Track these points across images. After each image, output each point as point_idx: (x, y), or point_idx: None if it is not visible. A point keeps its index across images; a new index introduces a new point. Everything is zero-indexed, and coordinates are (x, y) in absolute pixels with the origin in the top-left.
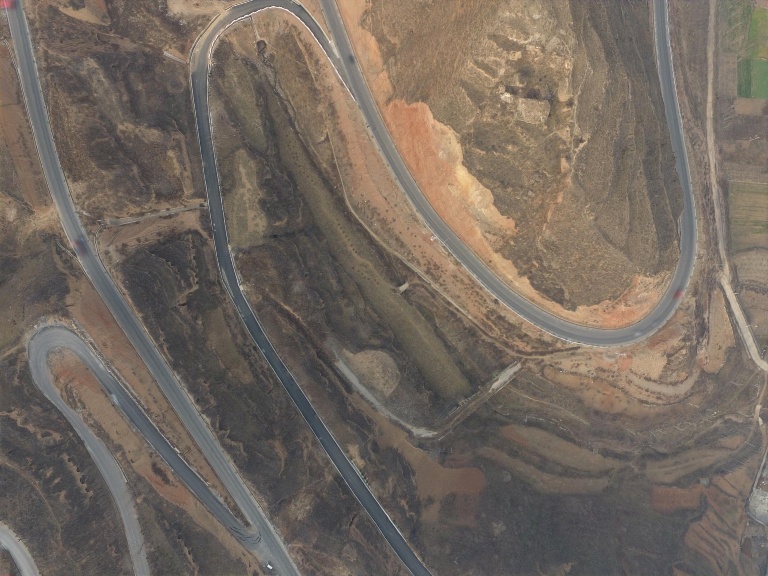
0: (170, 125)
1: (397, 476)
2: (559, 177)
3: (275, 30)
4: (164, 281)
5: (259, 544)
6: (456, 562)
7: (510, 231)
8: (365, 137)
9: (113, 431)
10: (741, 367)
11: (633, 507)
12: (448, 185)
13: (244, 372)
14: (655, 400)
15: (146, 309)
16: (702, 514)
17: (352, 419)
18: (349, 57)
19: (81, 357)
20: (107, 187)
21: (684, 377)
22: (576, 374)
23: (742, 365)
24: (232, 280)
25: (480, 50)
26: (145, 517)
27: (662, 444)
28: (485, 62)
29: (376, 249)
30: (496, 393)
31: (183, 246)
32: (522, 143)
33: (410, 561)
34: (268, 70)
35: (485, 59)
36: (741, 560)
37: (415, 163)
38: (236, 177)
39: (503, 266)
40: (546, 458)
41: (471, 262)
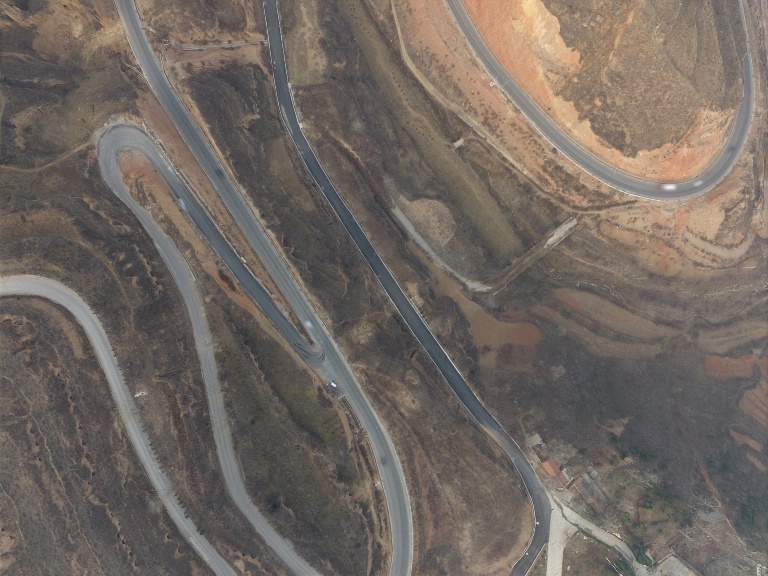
0: None
1: (454, 320)
2: None
3: None
4: (229, 101)
5: (323, 362)
6: (516, 402)
7: (574, 67)
8: None
9: (182, 230)
10: None
11: (687, 373)
12: (512, 20)
13: (306, 200)
14: (710, 263)
15: (213, 121)
16: (756, 383)
17: (410, 260)
18: None
19: (150, 158)
20: (174, 4)
21: (739, 240)
22: (632, 231)
23: None
24: (292, 117)
25: None
26: (213, 316)
27: (714, 315)
28: None
29: (431, 104)
30: (549, 256)
31: (246, 73)
32: None
33: (469, 401)
34: None
35: None
36: None
37: (476, 5)
38: (297, 16)
39: (563, 112)
40: (598, 323)
41: (530, 109)
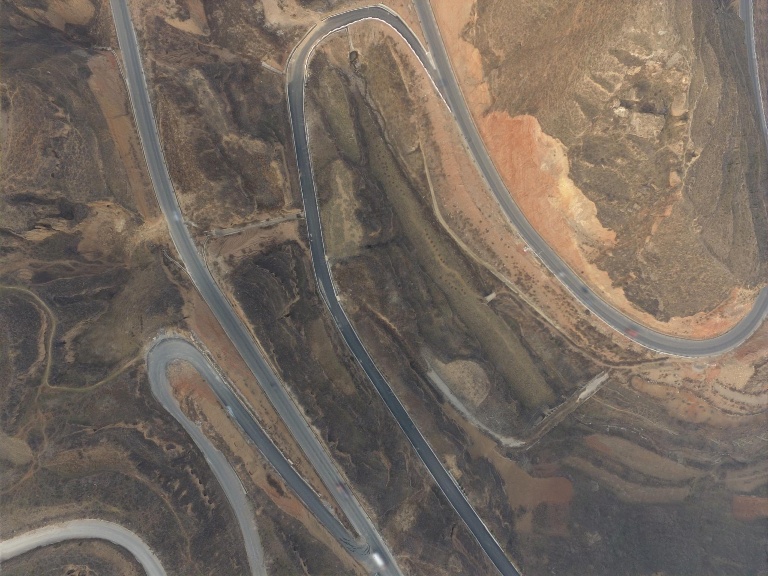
0: (271, 136)
1: (491, 486)
2: (668, 190)
3: (369, 41)
4: (271, 292)
5: (368, 555)
6: (553, 572)
7: (609, 243)
8: (460, 148)
9: (232, 443)
10: None
11: (715, 516)
12: (548, 197)
13: (346, 383)
14: (739, 410)
15: (257, 321)
16: None
17: (448, 429)
18: (446, 68)
19: (198, 369)
20: (216, 198)
21: (767, 387)
22: (663, 384)
23: None
24: (329, 290)
25: (599, 65)
26: (264, 529)
27: (741, 453)
28: (603, 77)
29: (463, 259)
30: None
31: (286, 257)
32: (632, 156)
33: (507, 571)
34: (359, 80)
35: (603, 74)
36: None
37: (511, 174)
38: (333, 188)
39: (596, 277)
40: (628, 467)
41: (563, 273)
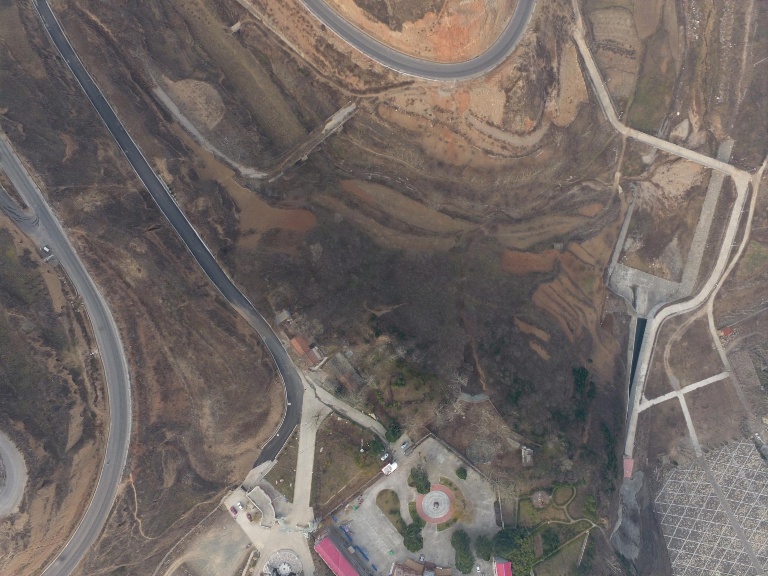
0: None
1: (213, 201)
2: None
3: None
4: None
5: (36, 227)
6: (266, 279)
7: None
8: None
9: None
10: (597, 128)
11: (480, 266)
12: None
13: (37, 67)
14: (501, 150)
15: None
16: (554, 277)
17: (163, 137)
18: None
19: None
20: None
21: (531, 127)
22: (413, 114)
23: (598, 127)
24: None
25: None
26: None
27: (516, 209)
28: None
29: None
30: (338, 147)
31: None
32: None
33: (219, 279)
34: None
35: None
36: (598, 330)
37: None
38: None
39: None
40: (390, 215)
41: None
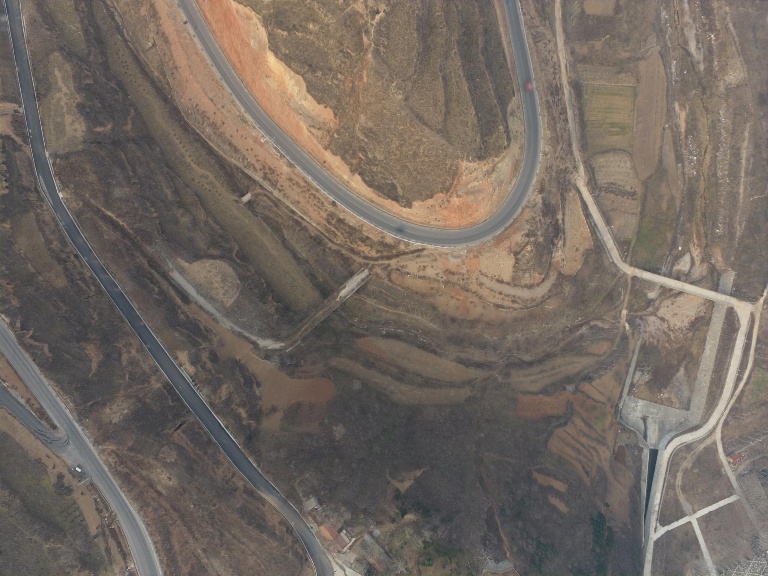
0: None
1: (234, 384)
2: (362, 54)
3: None
4: None
5: (67, 447)
6: (292, 466)
7: (332, 123)
8: (186, 36)
9: None
10: (603, 270)
11: (495, 415)
12: (265, 77)
13: (57, 276)
14: (511, 304)
15: None
16: (567, 420)
17: (183, 326)
18: None
19: None
20: None
21: (539, 279)
22: (425, 278)
23: (604, 269)
24: (51, 187)
25: None
26: None
27: (527, 353)
28: None
29: (216, 159)
30: (351, 305)
31: None
32: (322, 20)
33: (245, 468)
34: None
35: None
36: (612, 466)
37: (238, 61)
38: (52, 81)
39: (337, 165)
40: (405, 370)
41: (305, 163)
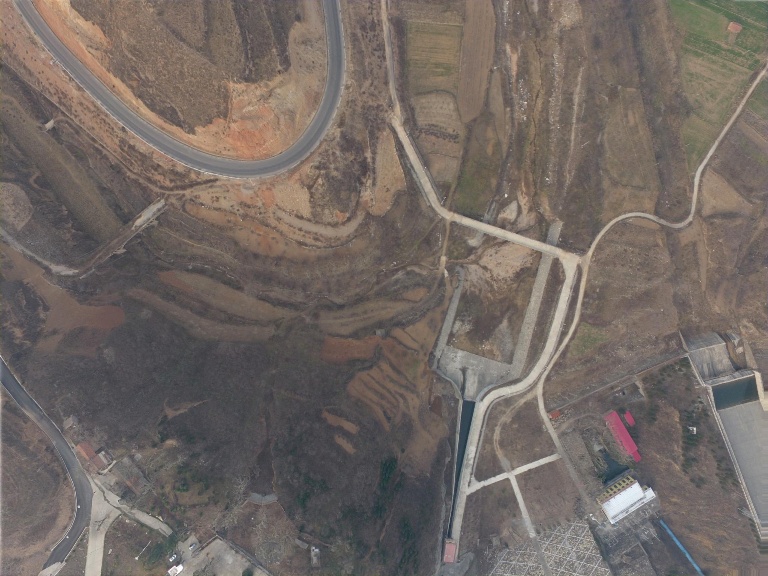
0: None
1: (12, 304)
2: None
3: None
4: None
5: None
6: (55, 385)
7: (105, 42)
8: None
9: None
10: (419, 214)
11: (297, 355)
12: None
13: None
14: (314, 242)
15: None
16: (373, 364)
17: None
18: None
19: None
20: None
21: (343, 218)
22: (221, 210)
23: (421, 212)
24: None
25: None
26: None
27: (339, 295)
28: None
29: (21, 85)
30: (157, 238)
31: None
32: None
33: (10, 385)
34: None
35: None
36: (421, 415)
37: None
38: None
39: (123, 89)
40: (209, 305)
41: (95, 87)
